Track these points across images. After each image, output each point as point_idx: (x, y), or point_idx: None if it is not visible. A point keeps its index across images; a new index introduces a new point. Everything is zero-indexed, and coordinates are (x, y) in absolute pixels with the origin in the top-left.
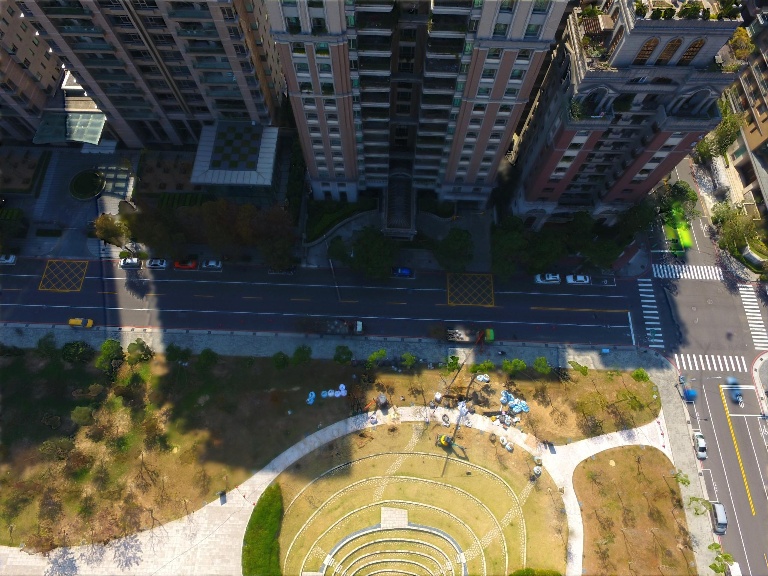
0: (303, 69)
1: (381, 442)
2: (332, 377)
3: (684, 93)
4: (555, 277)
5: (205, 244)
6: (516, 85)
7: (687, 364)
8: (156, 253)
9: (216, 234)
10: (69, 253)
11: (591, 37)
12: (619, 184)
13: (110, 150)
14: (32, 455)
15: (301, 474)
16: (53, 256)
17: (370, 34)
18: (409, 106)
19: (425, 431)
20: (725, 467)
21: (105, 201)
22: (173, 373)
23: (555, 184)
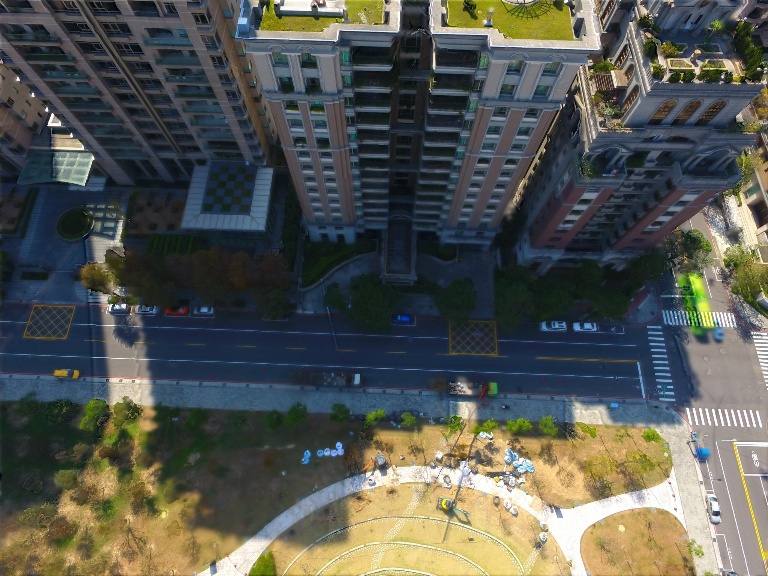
0: (297, 124)
1: (379, 505)
2: (328, 433)
3: (702, 152)
4: (561, 325)
5: (197, 288)
6: (523, 141)
7: (699, 419)
8: (145, 303)
9: (207, 286)
10: (55, 298)
11: (603, 94)
12: (629, 234)
13: (99, 187)
14: (13, 519)
15: (295, 541)
16: (39, 301)
17: (368, 91)
18: (409, 149)
19: (425, 493)
20: (740, 532)
21: (93, 242)
22: (162, 429)
23: (562, 234)
